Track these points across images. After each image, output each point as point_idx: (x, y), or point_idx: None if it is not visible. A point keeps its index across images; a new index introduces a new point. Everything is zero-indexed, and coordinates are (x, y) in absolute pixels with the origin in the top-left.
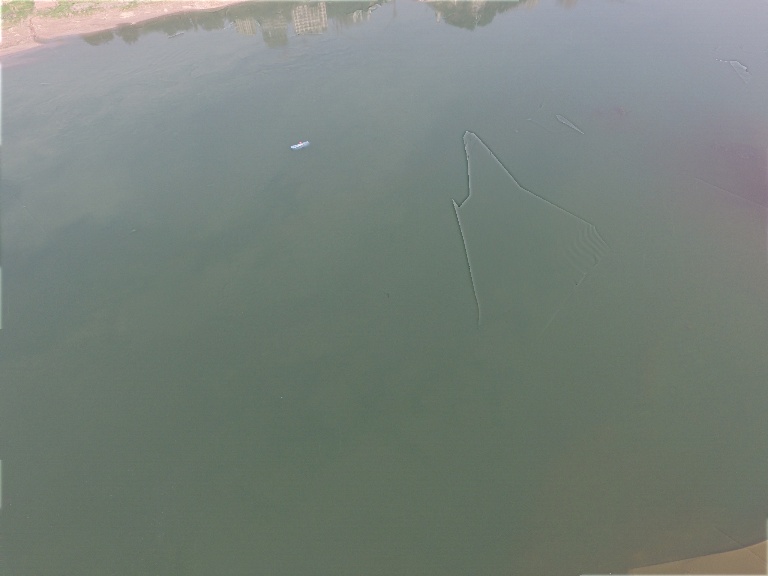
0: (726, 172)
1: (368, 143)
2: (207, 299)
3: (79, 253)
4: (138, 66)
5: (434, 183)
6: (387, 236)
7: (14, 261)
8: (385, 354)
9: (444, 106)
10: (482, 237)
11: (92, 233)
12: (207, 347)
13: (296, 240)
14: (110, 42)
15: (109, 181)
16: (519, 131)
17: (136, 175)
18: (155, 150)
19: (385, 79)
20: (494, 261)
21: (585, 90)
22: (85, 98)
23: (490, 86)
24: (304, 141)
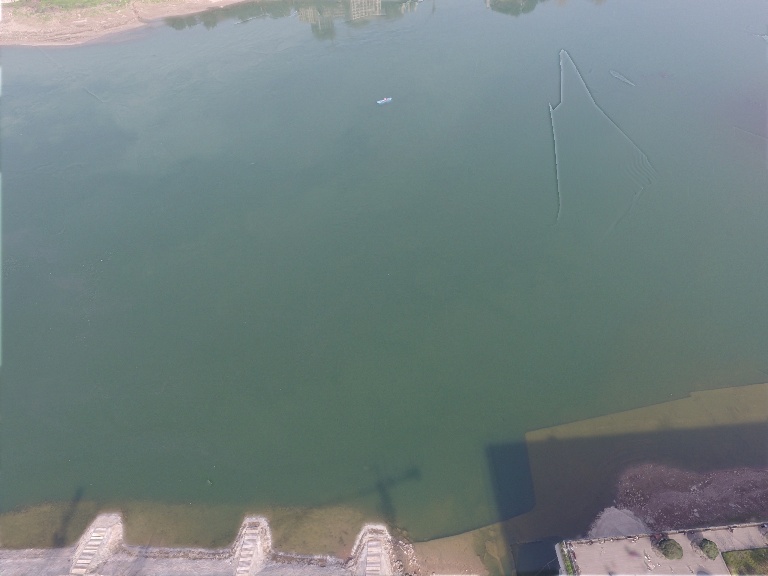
0: (760, 122)
1: (443, 97)
2: (323, 211)
3: (211, 179)
4: (231, 41)
5: (502, 130)
6: (465, 169)
7: (161, 183)
8: (484, 238)
9: (506, 69)
10: (567, 139)
11: (219, 165)
12: (330, 243)
13: (391, 170)
14: (193, 27)
15: (225, 128)
16: None
17: (246, 123)
18: (259, 105)
19: (450, 50)
20: (574, 162)
21: (630, 57)
22: (192, 65)
23: (544, 55)
24: (386, 97)
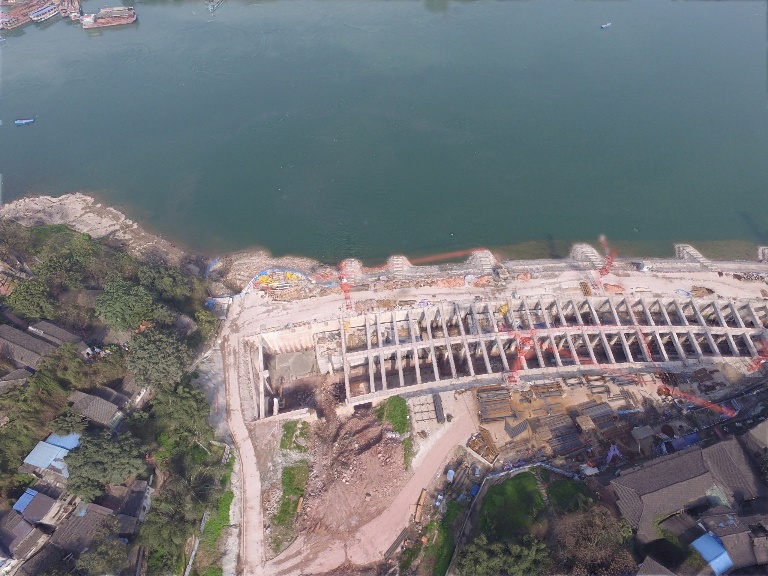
0: None
1: (661, 20)
2: (607, 93)
3: (501, 77)
4: None
5: (714, 44)
6: (698, 69)
7: (466, 79)
8: None
9: (699, 2)
10: None
11: (500, 68)
12: (627, 111)
13: (644, 67)
14: None
15: (485, 46)
16: (752, 21)
17: (500, 43)
18: (501, 31)
19: None
20: None
21: None
22: (426, 5)
23: None
24: None
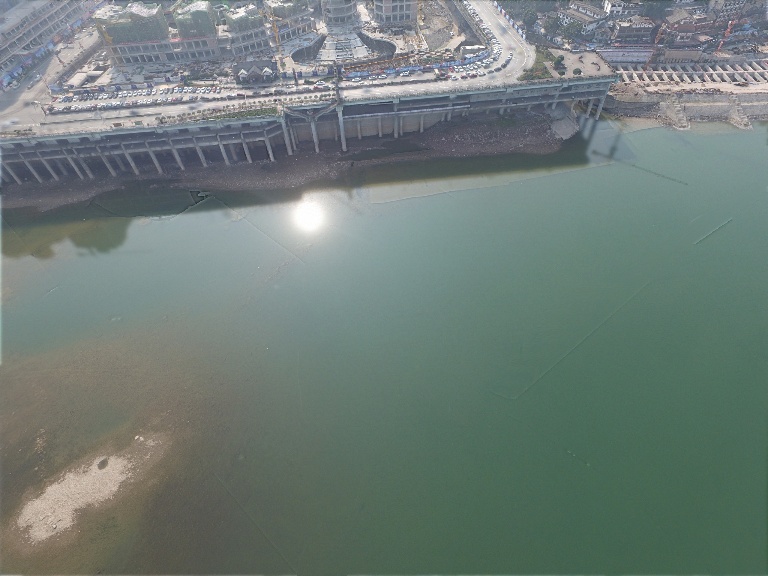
0: None
1: None
2: None
3: None
4: None
5: None
6: None
7: None
8: (712, 236)
9: None
10: None
11: None
12: None
13: None
14: None
15: None
16: None
17: None
18: None
19: None
20: None
21: None
22: None
23: None
24: None
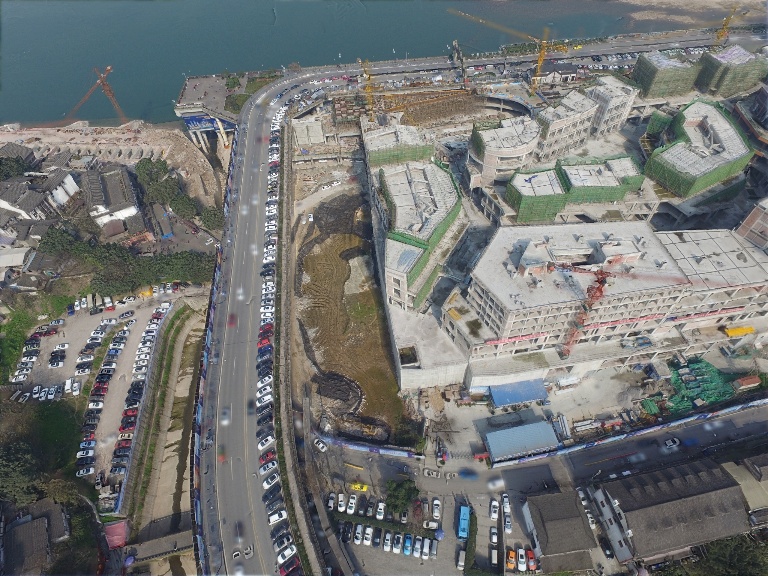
0: None
1: None
2: (160, 31)
3: (99, 23)
4: None
5: None
6: (258, 14)
7: (67, 25)
8: (230, 23)
9: None
10: None
11: (105, 17)
12: (158, 42)
13: (208, 13)
14: None
15: (115, 2)
16: None
17: None
18: None
19: None
20: None
21: None
22: None
23: None
24: None
